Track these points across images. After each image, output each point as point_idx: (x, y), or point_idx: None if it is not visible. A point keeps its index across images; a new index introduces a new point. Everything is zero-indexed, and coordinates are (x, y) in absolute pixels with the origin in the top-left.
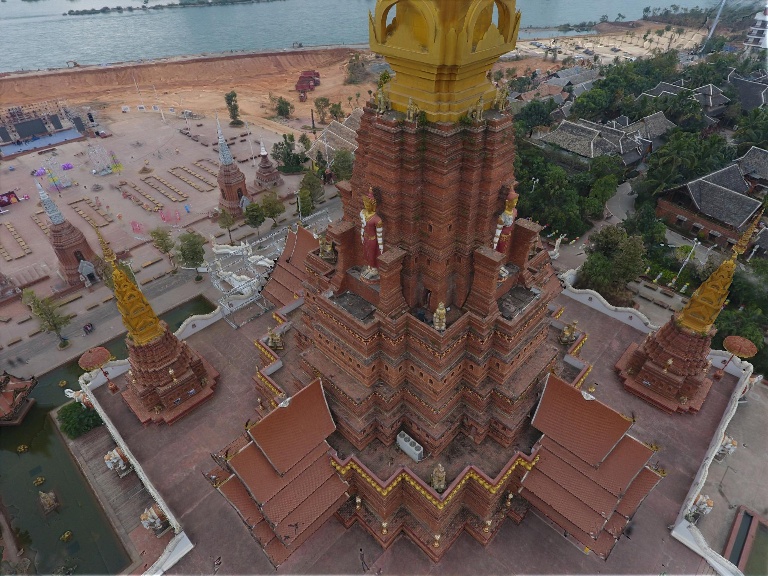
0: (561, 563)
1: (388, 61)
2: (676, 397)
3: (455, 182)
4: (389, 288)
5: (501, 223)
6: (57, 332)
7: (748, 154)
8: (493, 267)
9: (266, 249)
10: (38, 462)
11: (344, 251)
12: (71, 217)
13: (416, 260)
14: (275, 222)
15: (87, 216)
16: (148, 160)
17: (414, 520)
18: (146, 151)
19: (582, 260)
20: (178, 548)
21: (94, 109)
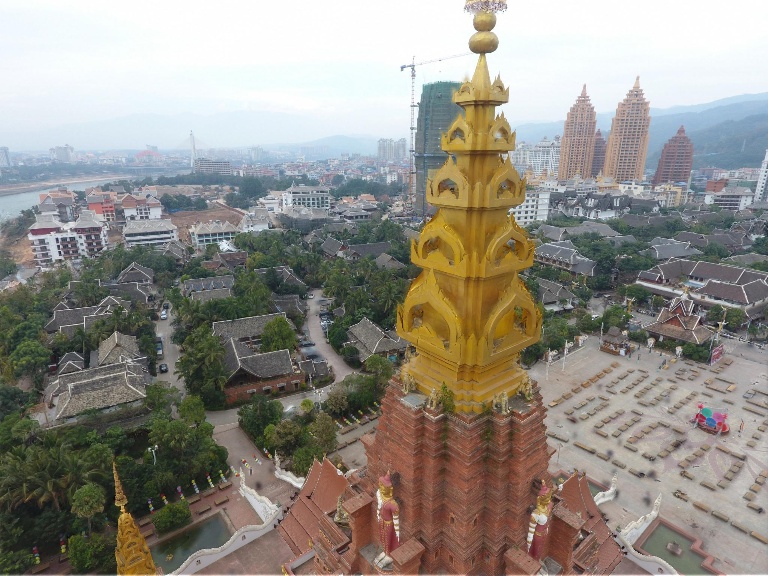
0: None
1: None
2: None
3: None
4: None
5: None
6: None
7: (215, 329)
8: None
9: None
10: None
11: None
12: None
13: None
14: None
15: None
16: None
17: None
18: None
19: (261, 473)
20: None
21: None
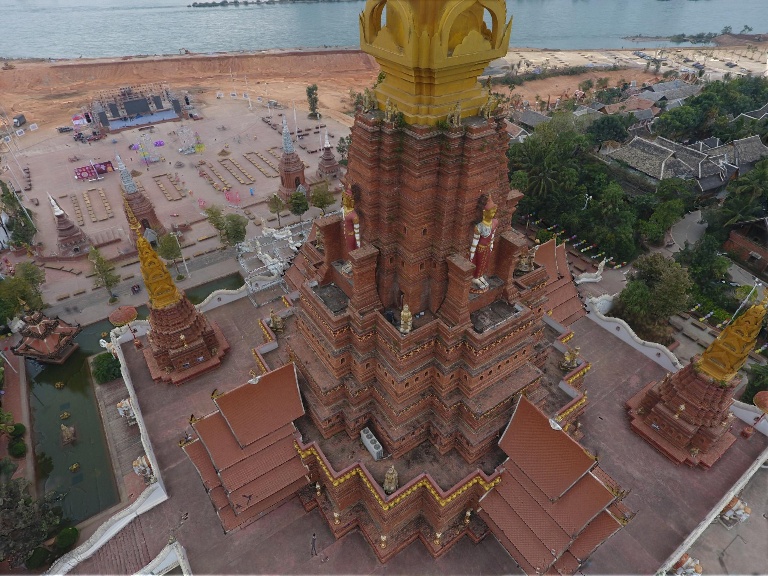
0: None
1: (377, 61)
2: (687, 447)
3: (430, 186)
4: (362, 284)
5: (477, 233)
6: (108, 288)
7: None
8: (462, 276)
9: None
10: (69, 399)
11: (328, 243)
12: (152, 189)
13: (392, 260)
14: None
15: (165, 189)
16: (228, 143)
17: (368, 517)
18: (229, 135)
19: None
20: (153, 496)
21: (194, 93)
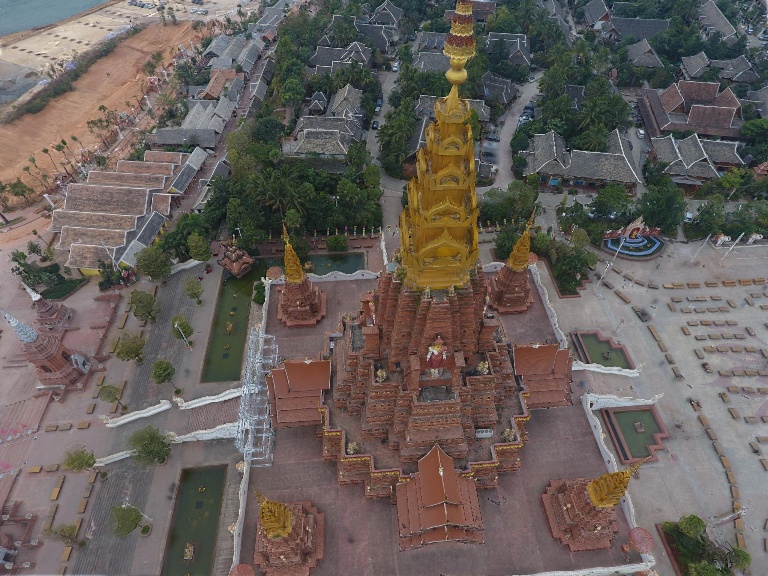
0: (552, 420)
1: None
2: None
3: None
4: None
5: None
6: None
7: (421, 101)
8: None
9: (183, 389)
10: None
11: None
12: None
13: None
14: (138, 357)
15: None
16: None
17: None
18: None
19: None
20: None
21: None
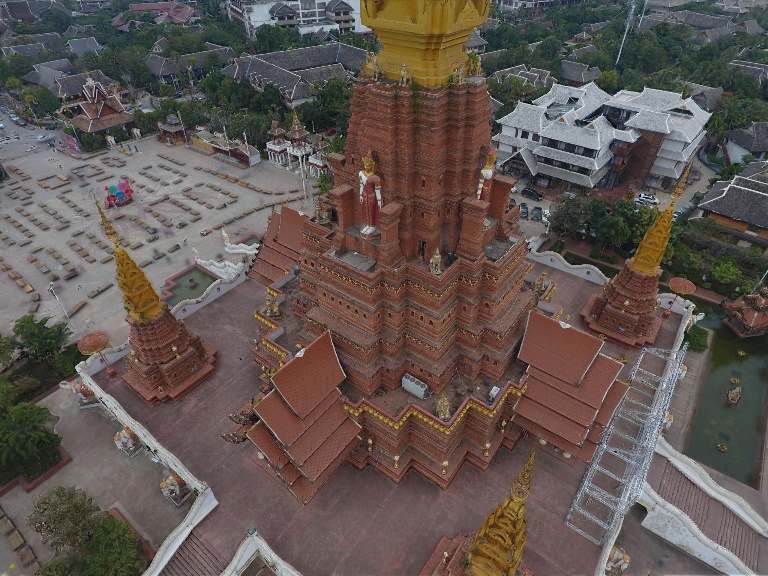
0: None
1: None
2: None
3: None
4: None
5: None
6: None
7: None
8: None
9: None
10: None
11: None
12: None
13: None
14: None
15: None
16: None
17: None
18: None
19: None
20: None
21: None
